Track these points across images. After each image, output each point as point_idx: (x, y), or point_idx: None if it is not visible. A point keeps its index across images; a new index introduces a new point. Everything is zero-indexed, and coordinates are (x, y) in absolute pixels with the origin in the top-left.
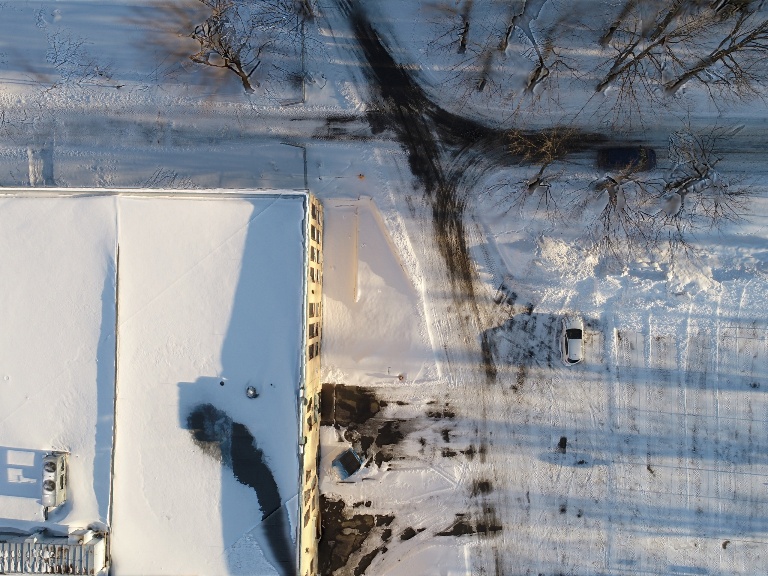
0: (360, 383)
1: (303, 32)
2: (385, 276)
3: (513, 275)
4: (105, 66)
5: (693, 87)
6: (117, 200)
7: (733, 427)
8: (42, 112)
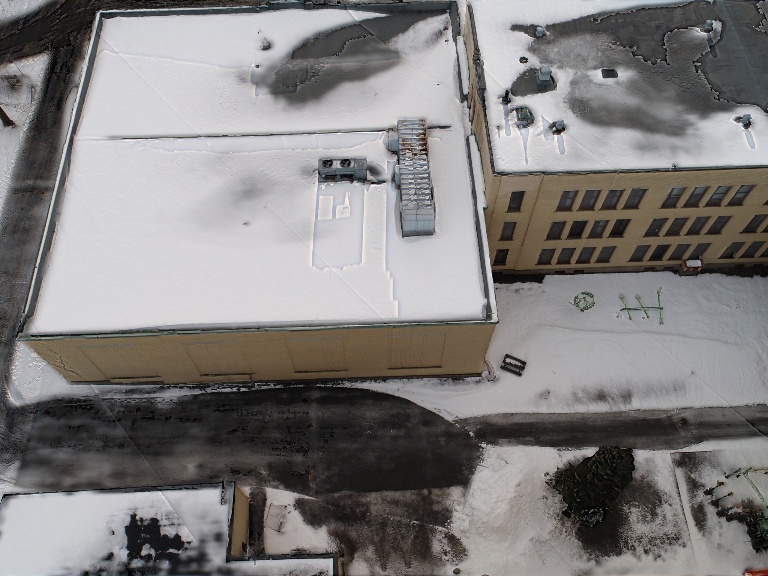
0: None
1: None
2: None
3: None
4: None
5: None
6: (79, 138)
7: None
8: None
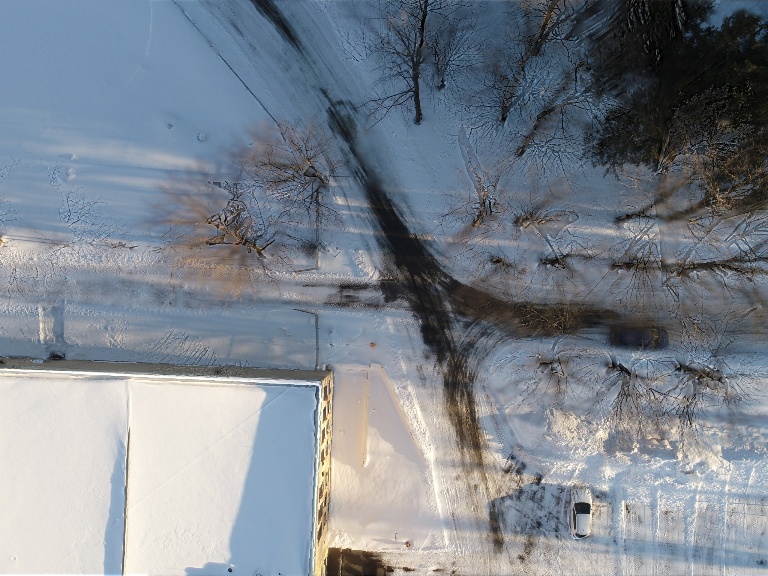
0: (367, 548)
1: (318, 200)
2: (394, 443)
3: (523, 446)
4: (118, 226)
5: (708, 277)
6: (129, 384)
7: None
8: (54, 270)
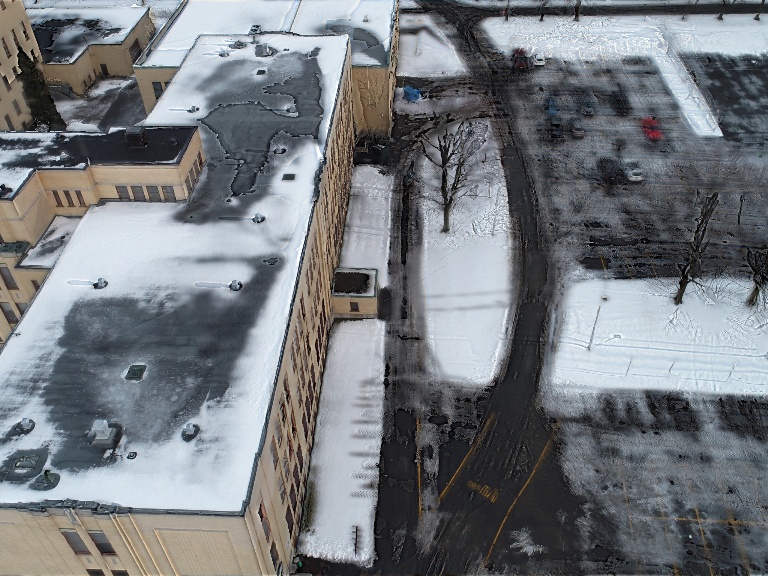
0: (419, 76)
1: None
2: (433, 46)
3: (502, 45)
4: None
5: None
6: None
7: (641, 83)
8: None
